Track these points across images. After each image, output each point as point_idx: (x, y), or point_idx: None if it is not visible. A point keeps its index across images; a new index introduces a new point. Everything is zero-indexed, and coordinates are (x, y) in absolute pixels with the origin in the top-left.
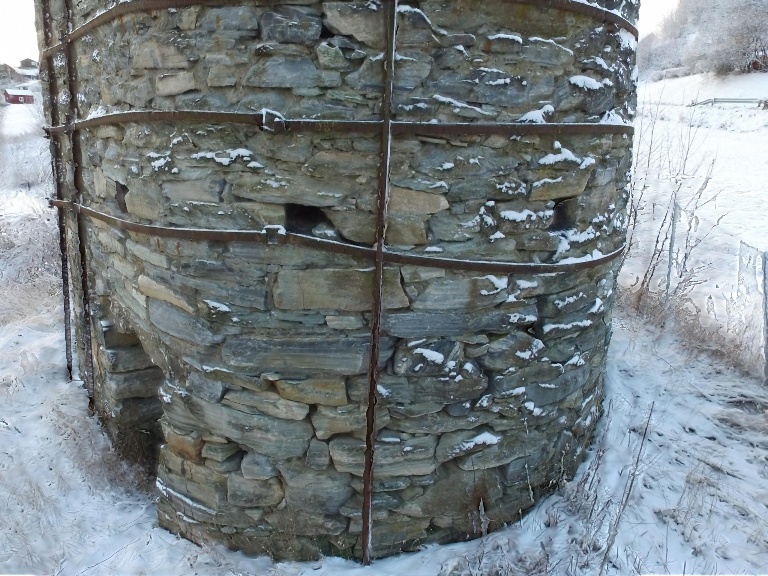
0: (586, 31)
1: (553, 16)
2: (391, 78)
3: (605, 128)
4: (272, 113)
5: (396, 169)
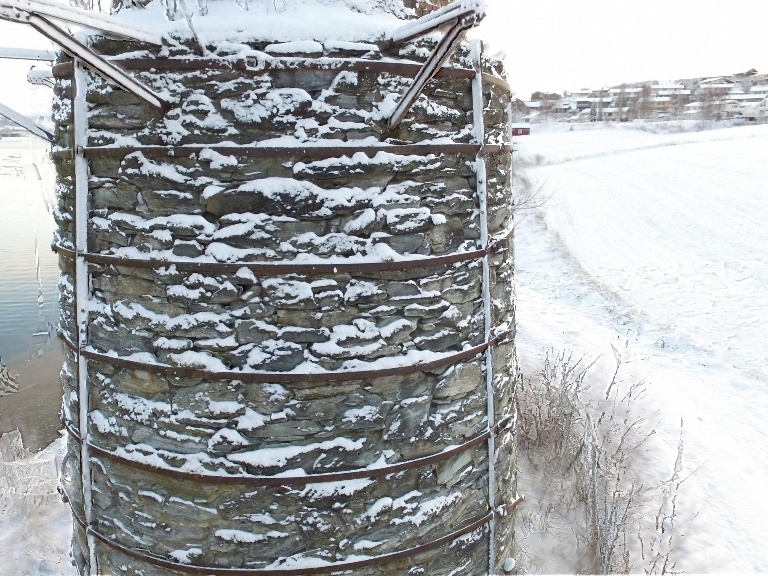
0: (236, 494)
1: (191, 484)
2: (84, 503)
3: (274, 573)
4: (63, 489)
5: (100, 556)
